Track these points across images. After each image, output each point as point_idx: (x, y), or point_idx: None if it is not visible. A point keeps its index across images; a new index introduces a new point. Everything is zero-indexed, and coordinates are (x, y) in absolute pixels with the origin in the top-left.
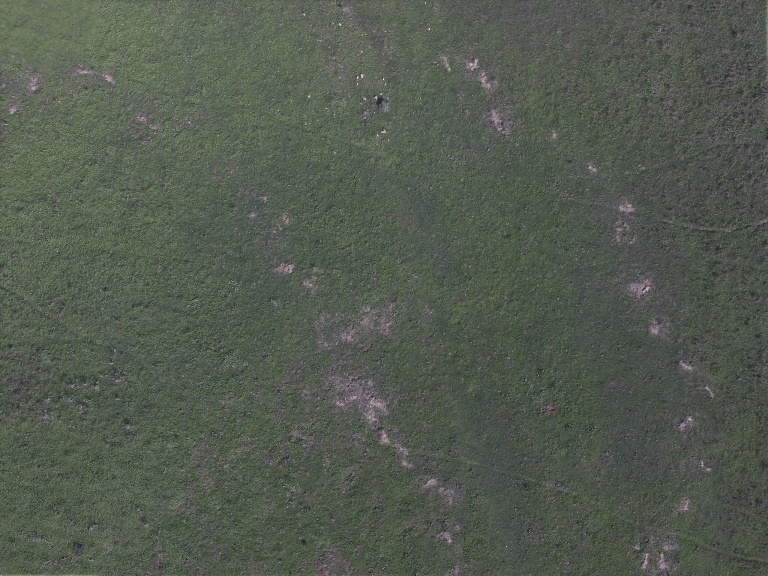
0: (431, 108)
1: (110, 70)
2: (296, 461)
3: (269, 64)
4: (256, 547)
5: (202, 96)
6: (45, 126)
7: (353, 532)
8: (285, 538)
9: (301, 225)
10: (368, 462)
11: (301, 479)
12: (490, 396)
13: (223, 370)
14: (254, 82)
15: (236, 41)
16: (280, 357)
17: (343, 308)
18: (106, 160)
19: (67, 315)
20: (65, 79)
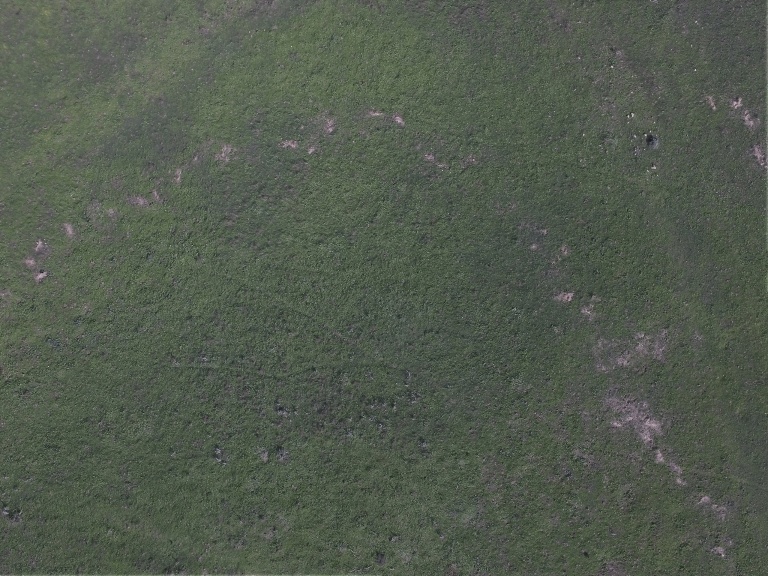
0: (697, 145)
1: (400, 112)
2: (577, 478)
3: (546, 105)
4: (542, 559)
5: (484, 135)
6: (341, 164)
7: (632, 546)
8: (568, 551)
9: (579, 256)
10: (645, 480)
11: (583, 495)
12: (757, 418)
13: (509, 392)
14: (532, 122)
15: (515, 83)
16: (561, 380)
17: (619, 334)
18: (397, 196)
19: (365, 340)
20: (358, 120)
